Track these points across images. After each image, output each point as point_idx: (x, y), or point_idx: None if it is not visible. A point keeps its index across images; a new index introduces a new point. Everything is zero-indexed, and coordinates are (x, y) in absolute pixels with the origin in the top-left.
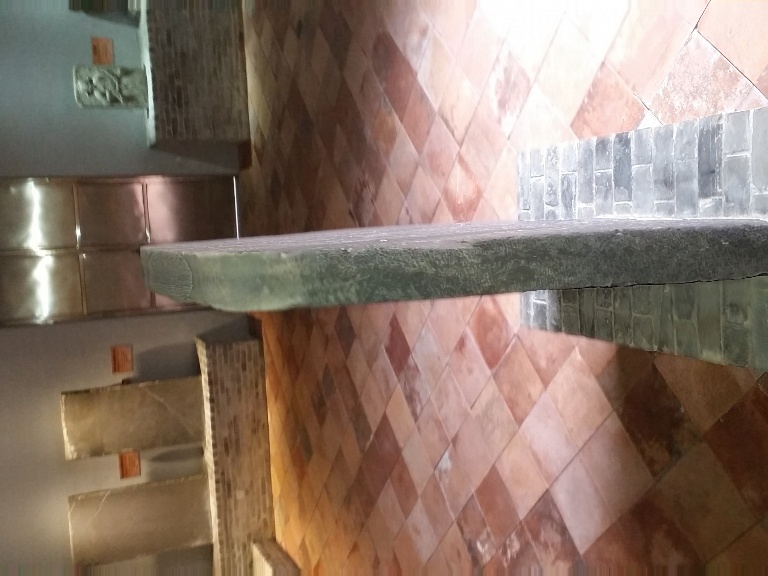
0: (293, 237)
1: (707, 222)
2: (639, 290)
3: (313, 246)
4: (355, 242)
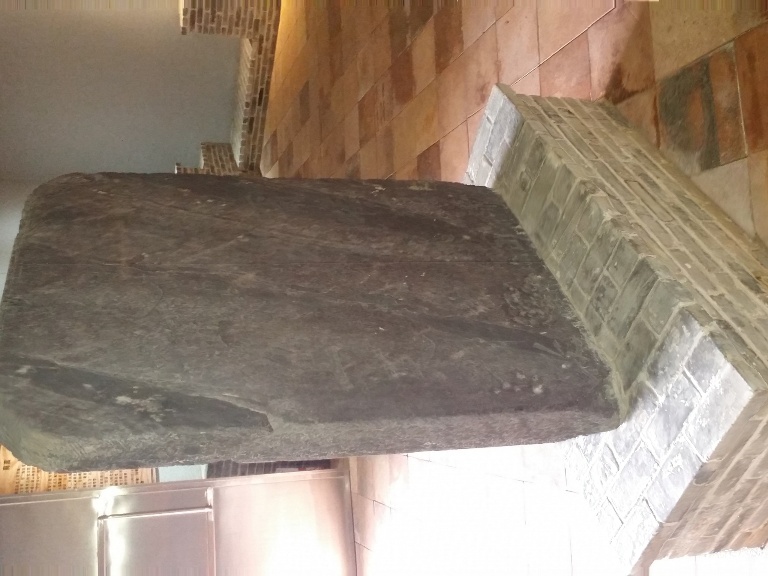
0: None
1: None
2: (572, 263)
3: None
4: None
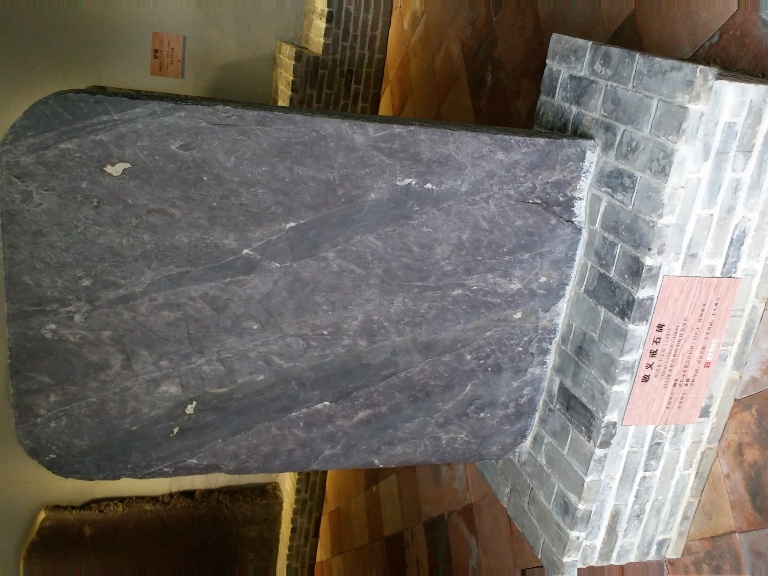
0: (190, 204)
1: (475, 437)
2: None
3: (103, 459)
4: (158, 421)
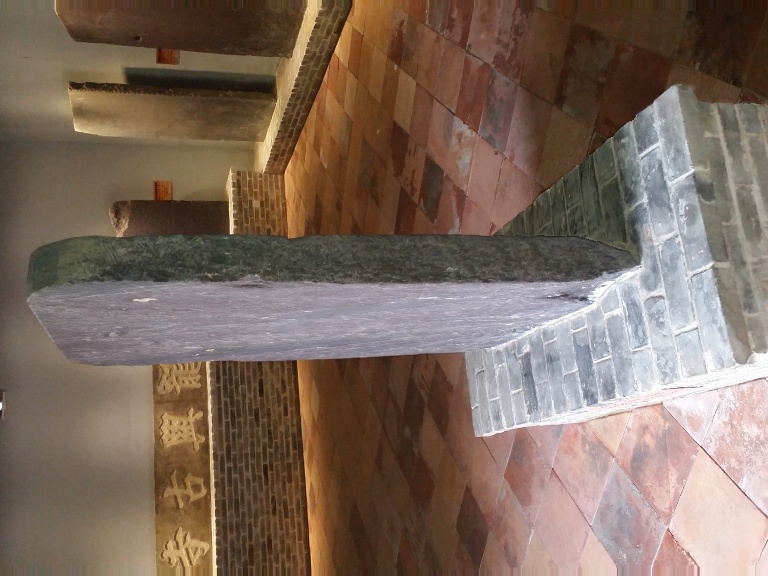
0: (214, 308)
1: None
2: None
3: None
4: None
